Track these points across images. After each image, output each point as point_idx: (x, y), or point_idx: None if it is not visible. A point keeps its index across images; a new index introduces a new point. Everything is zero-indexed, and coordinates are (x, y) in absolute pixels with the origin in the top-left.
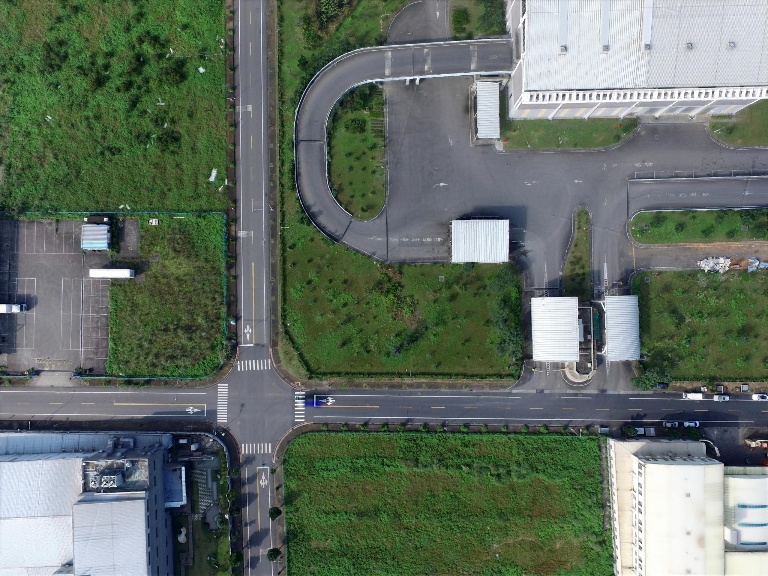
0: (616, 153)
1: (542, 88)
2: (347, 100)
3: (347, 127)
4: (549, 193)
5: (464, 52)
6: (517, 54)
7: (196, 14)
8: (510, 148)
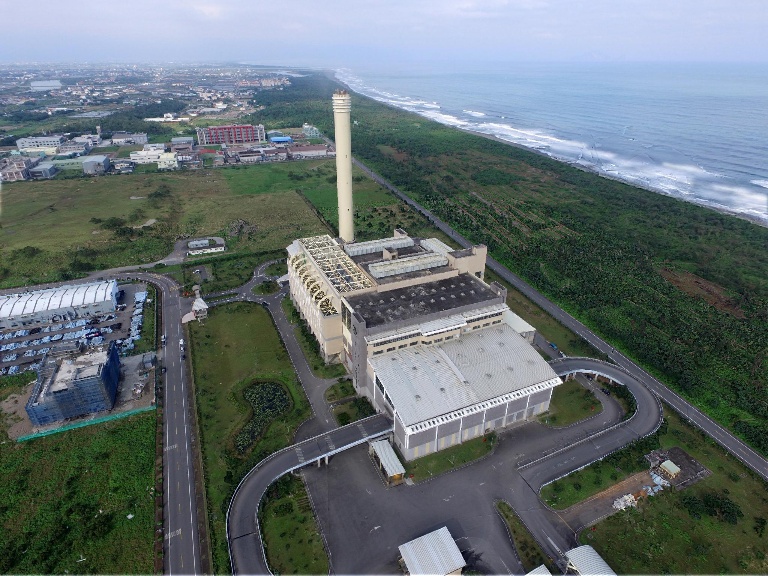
0: (495, 456)
1: (417, 422)
2: (272, 490)
3: (276, 512)
4: (467, 500)
5: (354, 430)
6: (391, 415)
7: (128, 478)
8: (418, 480)
